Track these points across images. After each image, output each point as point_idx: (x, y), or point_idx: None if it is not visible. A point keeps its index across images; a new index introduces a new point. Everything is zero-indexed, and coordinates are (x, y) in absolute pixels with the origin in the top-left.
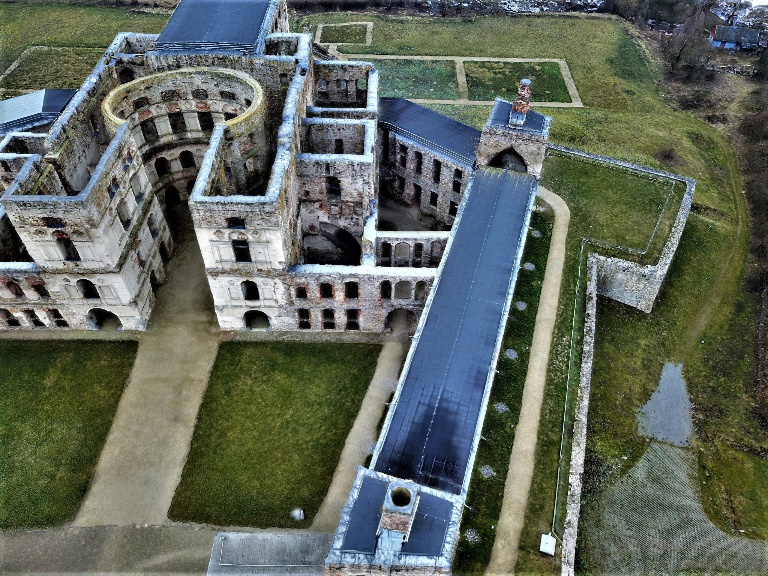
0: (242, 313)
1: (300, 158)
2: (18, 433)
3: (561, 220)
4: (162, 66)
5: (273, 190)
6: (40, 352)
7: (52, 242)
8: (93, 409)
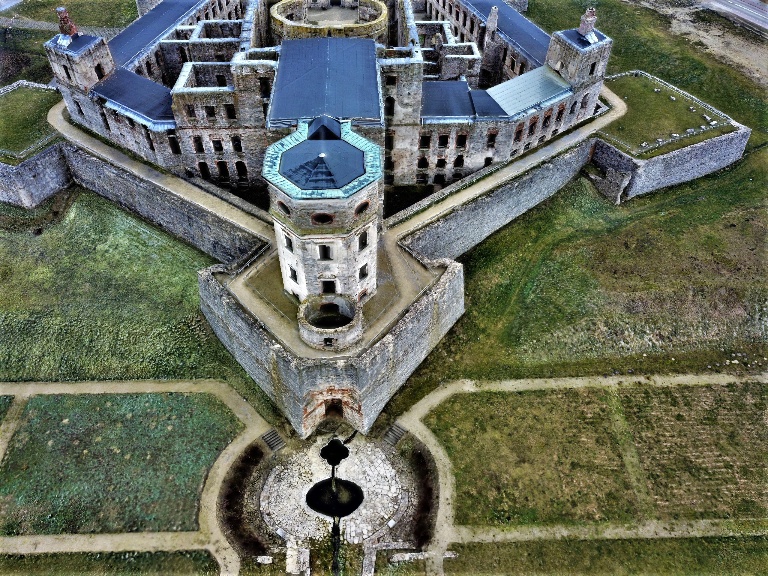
0: None
1: None
2: None
3: (63, 104)
4: None
5: None
6: None
7: None
8: None
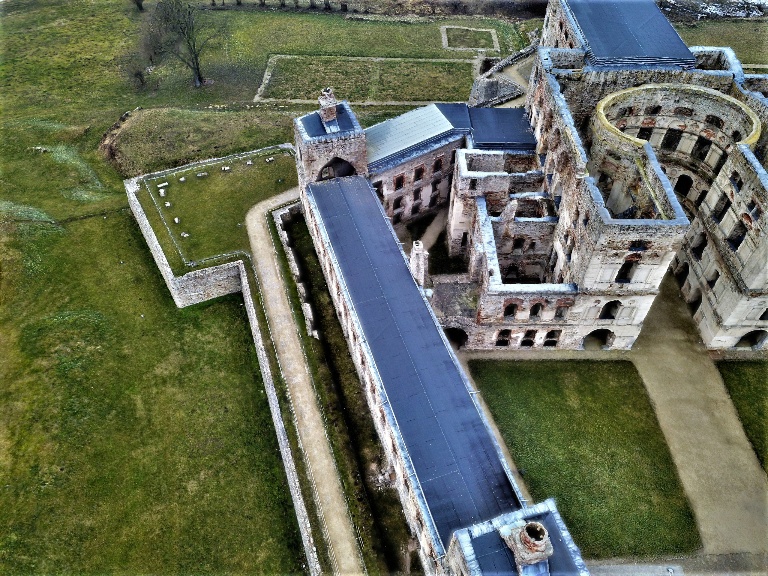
0: (745, 333)
1: None
2: (582, 457)
3: None
4: (598, 81)
5: None
6: (542, 373)
7: (619, 265)
8: (639, 432)
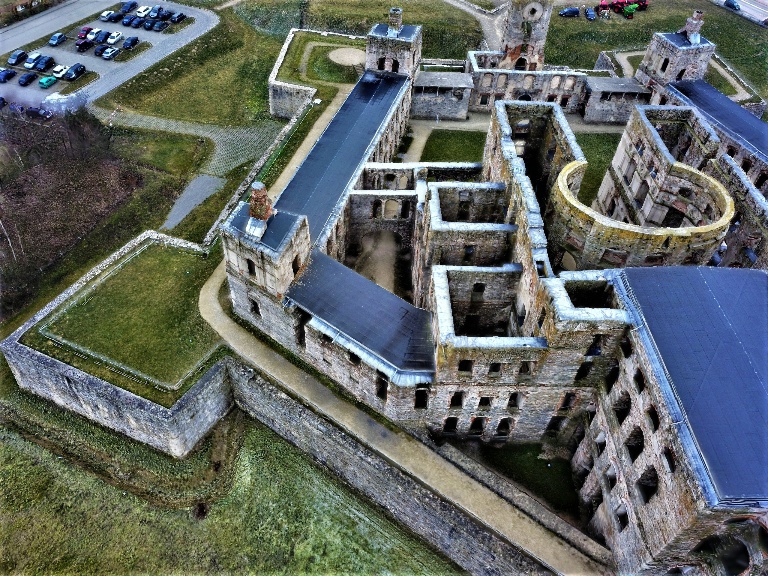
0: None
1: (499, 183)
2: None
3: (216, 281)
4: None
5: (501, 107)
6: None
7: None
8: None
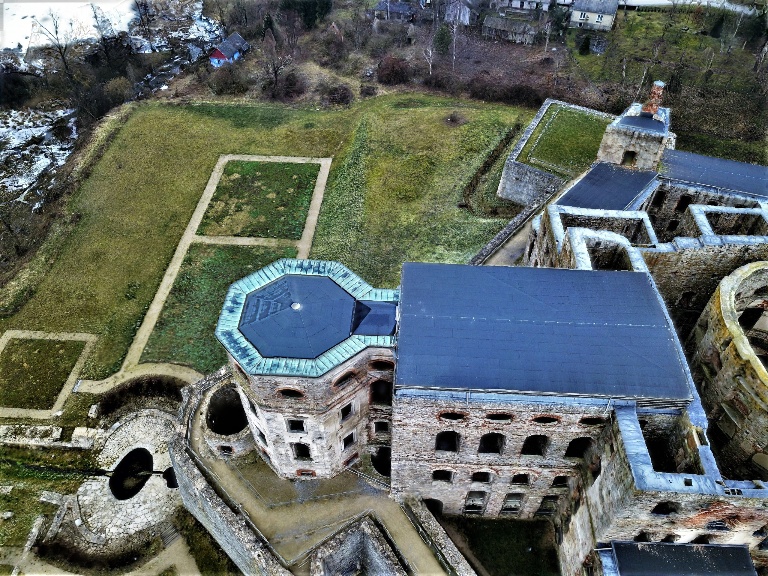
0: None
1: None
2: None
3: None
4: None
5: None
6: None
7: None
8: None
